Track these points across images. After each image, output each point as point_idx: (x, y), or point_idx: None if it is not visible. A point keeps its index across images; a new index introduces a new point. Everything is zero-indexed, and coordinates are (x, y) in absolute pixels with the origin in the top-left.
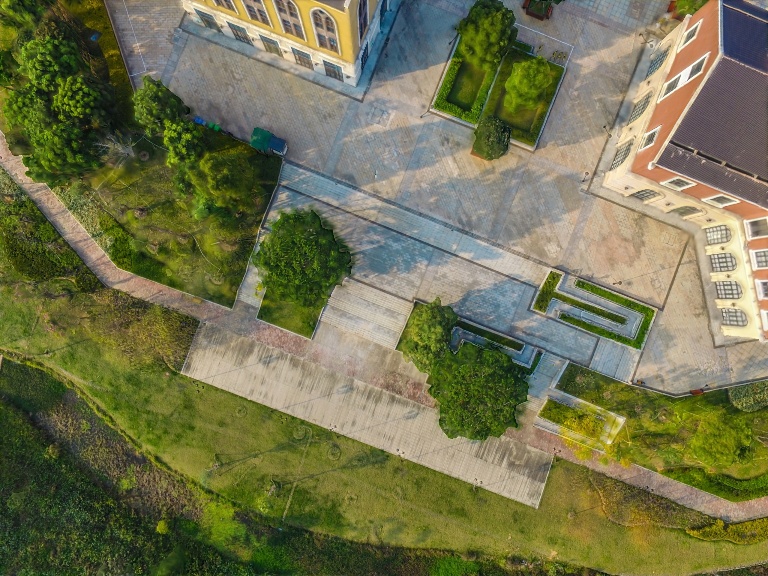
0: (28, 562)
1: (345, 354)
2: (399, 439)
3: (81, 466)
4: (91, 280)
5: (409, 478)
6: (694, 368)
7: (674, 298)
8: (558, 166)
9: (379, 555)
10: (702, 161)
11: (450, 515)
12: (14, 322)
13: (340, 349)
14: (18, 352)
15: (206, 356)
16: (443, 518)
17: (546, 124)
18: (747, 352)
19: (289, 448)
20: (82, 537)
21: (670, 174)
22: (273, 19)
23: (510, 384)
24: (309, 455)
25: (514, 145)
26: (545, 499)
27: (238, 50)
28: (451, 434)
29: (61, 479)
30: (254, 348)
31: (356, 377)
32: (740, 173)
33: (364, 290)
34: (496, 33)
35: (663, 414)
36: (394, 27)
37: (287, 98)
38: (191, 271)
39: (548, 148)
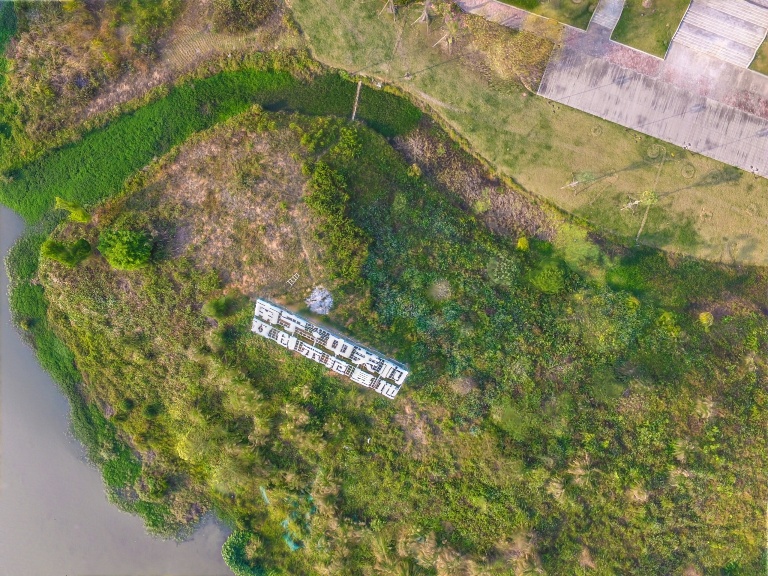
0: (411, 263)
1: (697, 74)
2: (753, 156)
3: (438, 188)
4: (451, 3)
5: (763, 195)
6: None
7: None
8: None
9: (733, 273)
10: None
11: None
12: (375, 46)
13: (692, 69)
14: (377, 77)
15: (561, 77)
16: None
17: None
18: None
19: (644, 167)
20: (454, 246)
21: None
22: None
23: None
24: (663, 173)
25: None
26: None
27: None
28: None
29: (424, 197)
30: (608, 69)
31: (708, 96)
32: None
33: (726, 1)
34: None
35: None
36: None
37: None
38: None
39: None
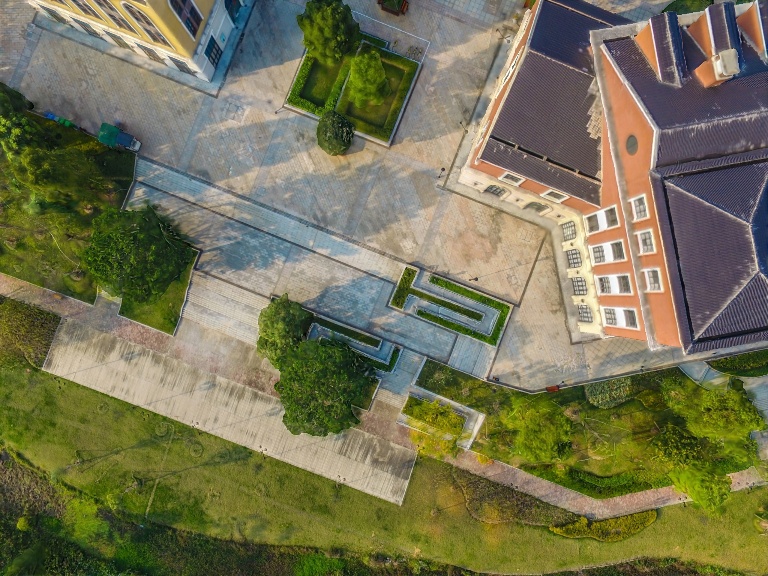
0: None
1: (207, 350)
2: (262, 436)
3: None
4: None
5: (272, 475)
6: (550, 365)
7: (531, 294)
8: (414, 162)
9: (242, 552)
10: (524, 156)
11: (313, 512)
12: None
13: (202, 345)
14: None
15: (67, 352)
16: (306, 515)
17: (402, 120)
18: (604, 349)
19: (151, 445)
20: None
21: (499, 169)
22: (101, 14)
23: (343, 380)
24: (171, 452)
25: (370, 141)
26: (409, 496)
27: (92, 45)
28: (293, 430)
29: None
30: (116, 344)
31: (218, 374)
32: (562, 168)
33: (222, 286)
34: (328, 28)
35: (519, 411)
36: (249, 22)
37: (141, 94)
38: (50, 267)
39: (404, 144)
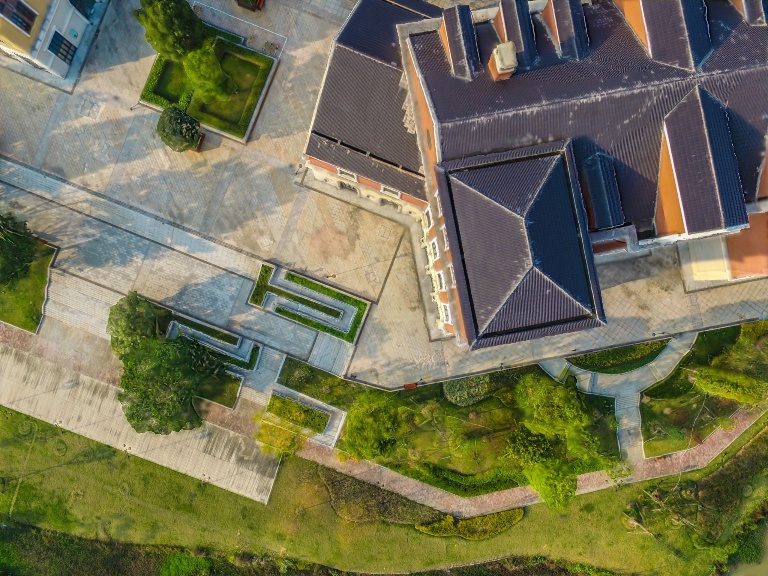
0: None
1: (71, 349)
2: (126, 434)
3: None
4: None
5: (136, 474)
6: (409, 362)
7: (389, 291)
8: (271, 158)
9: (107, 552)
10: (347, 151)
11: (178, 511)
12: None
13: (66, 344)
14: None
15: None
16: (171, 514)
17: (259, 116)
18: (463, 346)
19: (14, 444)
20: None
21: (329, 165)
22: None
23: (178, 377)
24: (34, 451)
25: (226, 137)
26: (274, 495)
27: None
28: (136, 428)
29: None
30: None
31: (82, 372)
32: (385, 163)
33: (80, 284)
34: (160, 23)
35: None
36: (105, 19)
37: None
38: None
39: (261, 140)
